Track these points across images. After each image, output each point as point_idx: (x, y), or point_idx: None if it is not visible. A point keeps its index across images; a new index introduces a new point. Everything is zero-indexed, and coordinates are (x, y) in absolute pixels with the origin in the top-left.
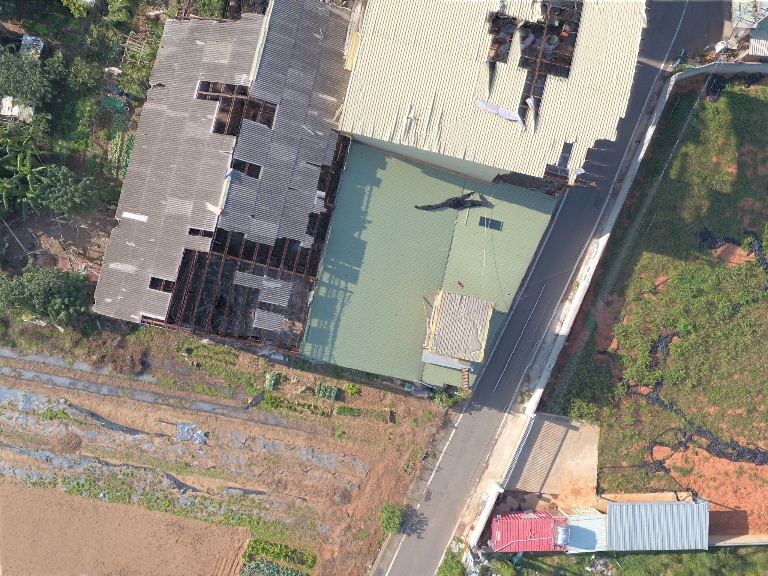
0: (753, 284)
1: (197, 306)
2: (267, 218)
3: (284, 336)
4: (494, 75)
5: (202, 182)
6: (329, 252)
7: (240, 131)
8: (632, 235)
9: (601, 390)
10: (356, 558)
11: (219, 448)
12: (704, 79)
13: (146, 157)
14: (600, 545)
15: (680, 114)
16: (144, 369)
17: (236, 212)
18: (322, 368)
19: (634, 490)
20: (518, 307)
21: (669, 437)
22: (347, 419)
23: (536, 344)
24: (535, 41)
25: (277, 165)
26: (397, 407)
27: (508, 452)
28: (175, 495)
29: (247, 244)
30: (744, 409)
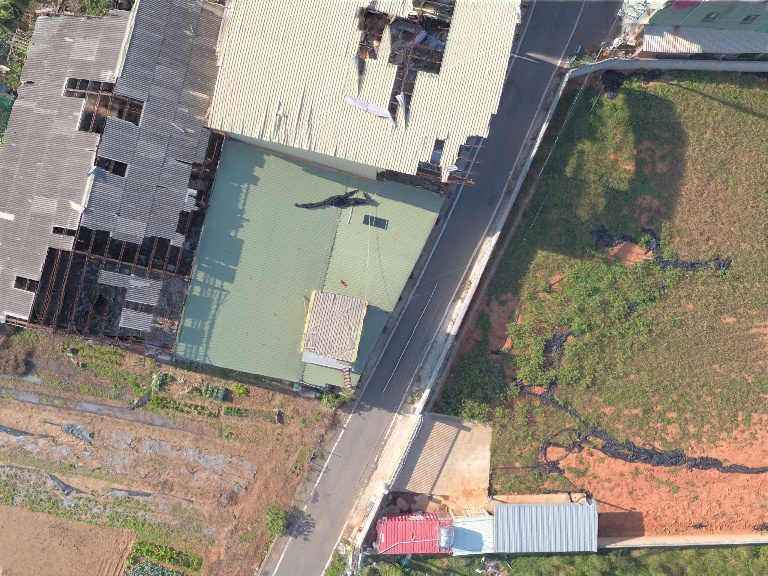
0: (650, 283)
1: (76, 306)
2: (134, 216)
3: (163, 336)
4: (363, 71)
5: (66, 180)
6: (204, 251)
7: (104, 128)
8: (527, 233)
9: (493, 390)
10: (242, 560)
11: (104, 449)
12: (602, 76)
13: (15, 155)
14: (487, 547)
15: (577, 111)
16: (28, 369)
17: (100, 210)
18: (210, 368)
19: (527, 491)
20: (409, 306)
21: (563, 437)
22: (235, 420)
23: (427, 344)
24: (427, 38)
25: (144, 163)
26: (285, 407)
27: (398, 453)
28: (59, 497)
29: (113, 243)
30: (640, 409)
